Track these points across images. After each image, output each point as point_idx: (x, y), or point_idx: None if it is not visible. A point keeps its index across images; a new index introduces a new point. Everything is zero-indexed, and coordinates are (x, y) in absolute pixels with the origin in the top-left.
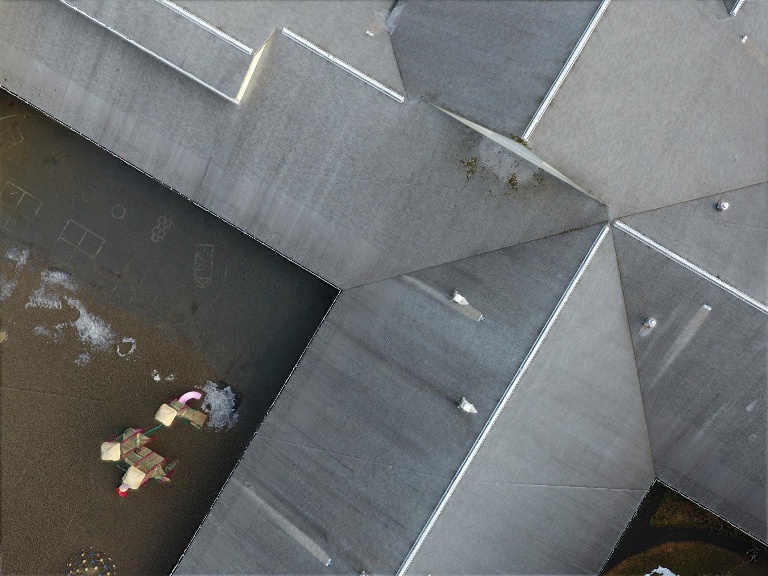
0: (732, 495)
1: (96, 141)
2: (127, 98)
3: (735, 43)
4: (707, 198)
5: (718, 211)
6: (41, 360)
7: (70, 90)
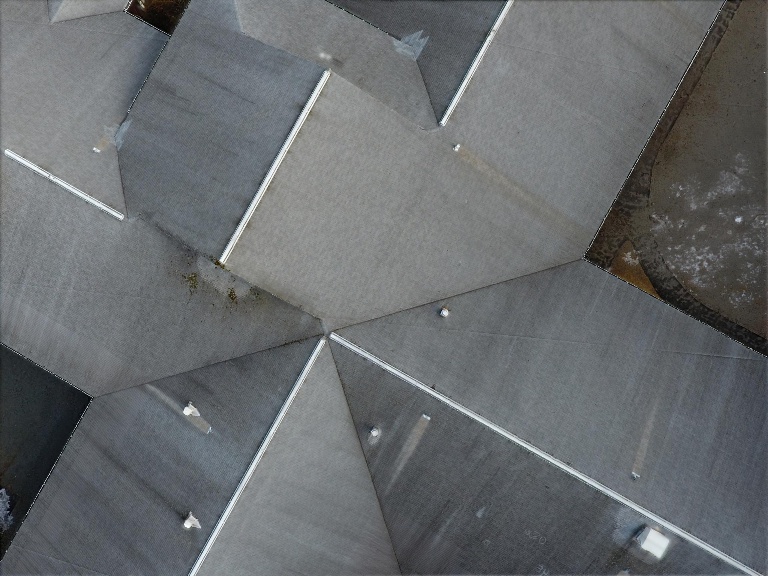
0: None
1: None
2: None
3: (447, 152)
4: (431, 304)
5: (442, 317)
6: None
7: None
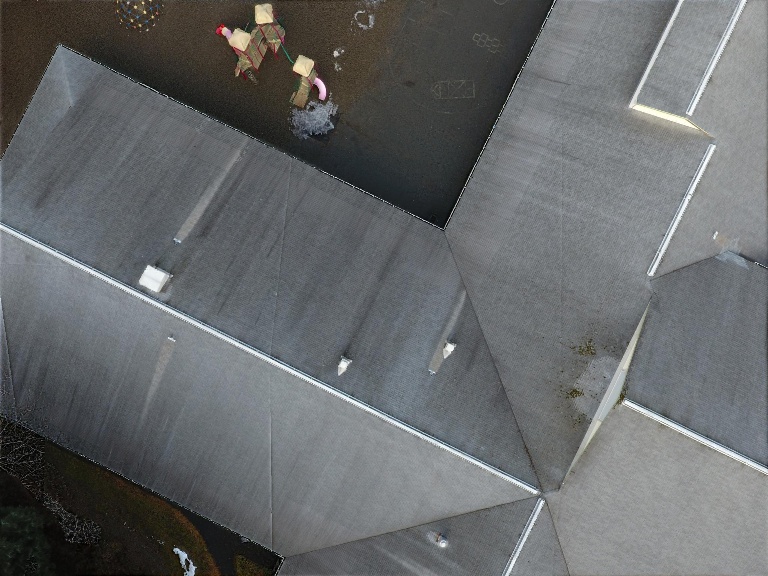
0: None
1: None
2: None
3: None
4: None
5: None
6: None
7: None
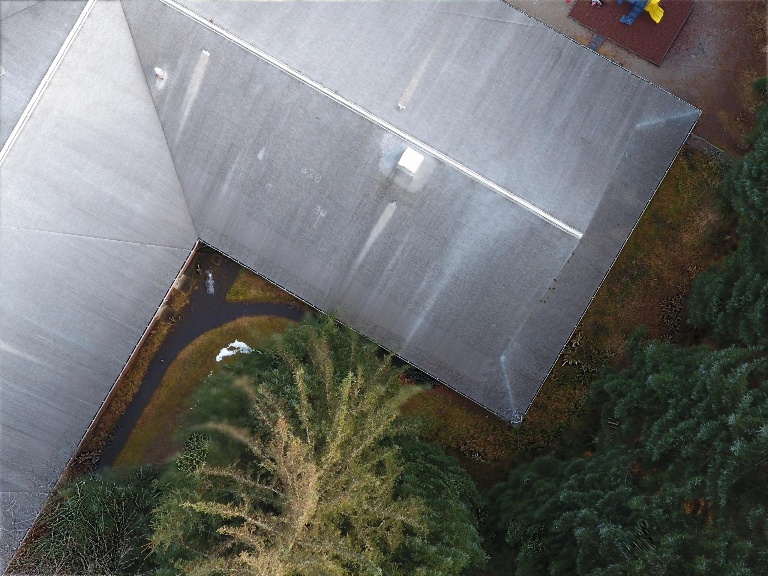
0: (263, 250)
1: None
2: None
3: None
4: None
5: None
6: None
7: None
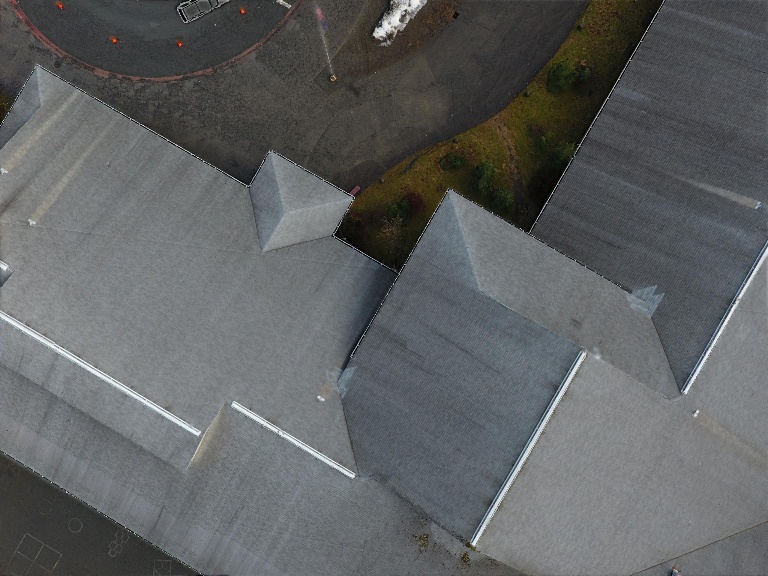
0: None
1: (49, 479)
2: (79, 445)
3: (687, 419)
4: (662, 565)
5: None
6: None
7: (21, 432)
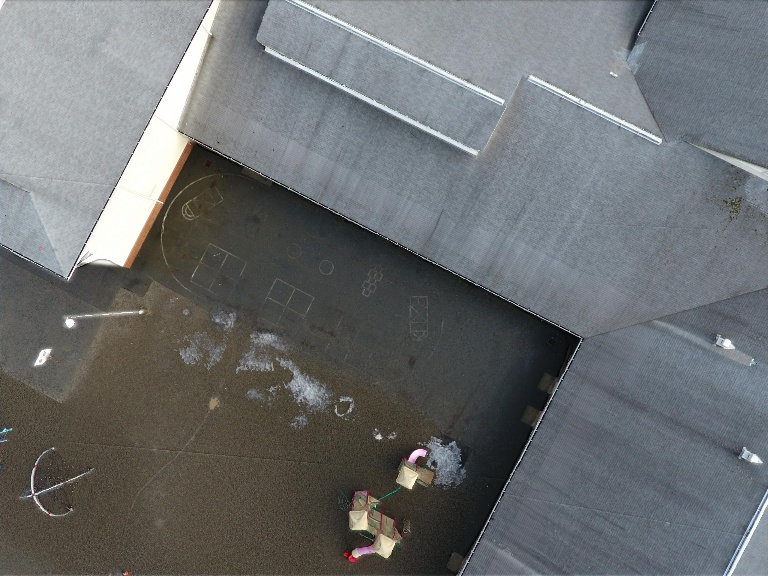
0: None
1: (316, 199)
2: (352, 154)
3: None
4: None
5: None
6: (256, 425)
7: (289, 149)
